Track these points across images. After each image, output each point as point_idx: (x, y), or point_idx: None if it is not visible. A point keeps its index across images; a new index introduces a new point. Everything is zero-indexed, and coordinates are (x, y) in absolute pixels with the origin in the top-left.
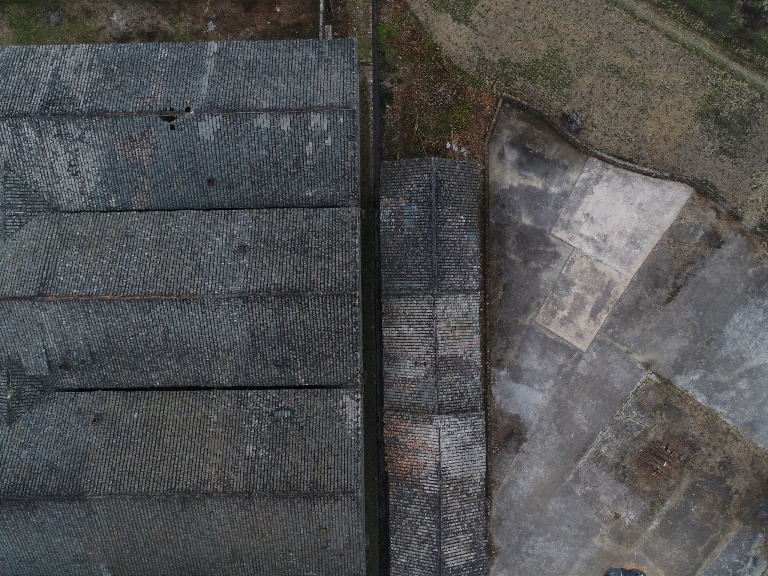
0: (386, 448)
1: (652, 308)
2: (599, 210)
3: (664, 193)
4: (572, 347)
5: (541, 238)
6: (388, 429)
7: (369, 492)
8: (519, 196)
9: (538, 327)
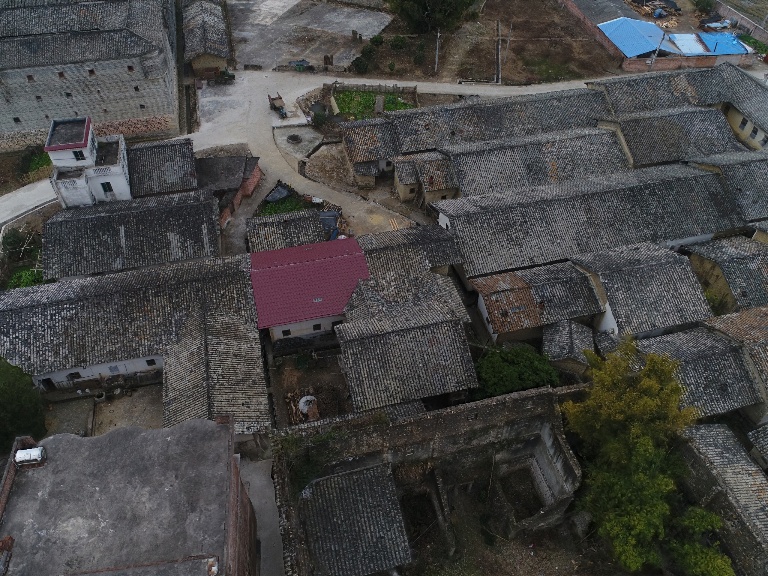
0: (183, 29)
1: (294, 16)
2: None
3: None
4: None
5: None
6: (184, 25)
7: (179, 56)
8: (238, 4)
9: None
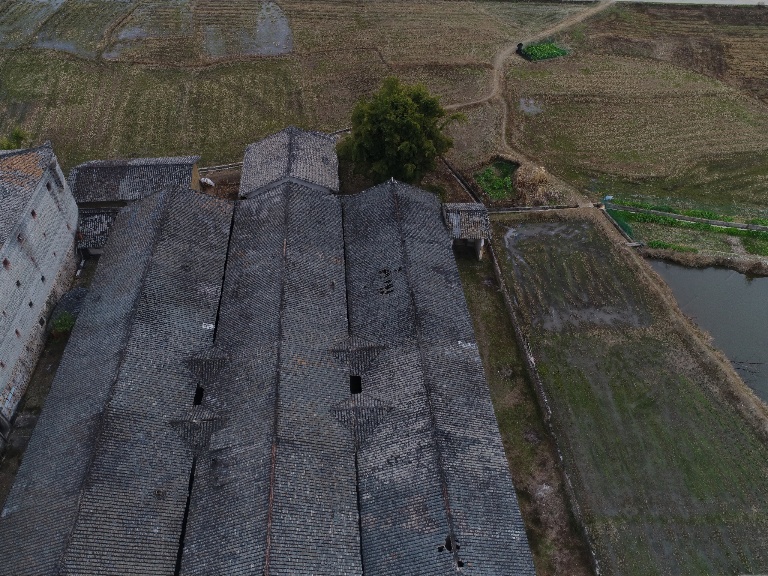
0: None
1: None
2: None
3: None
4: None
5: None
6: None
7: None
8: None
9: None
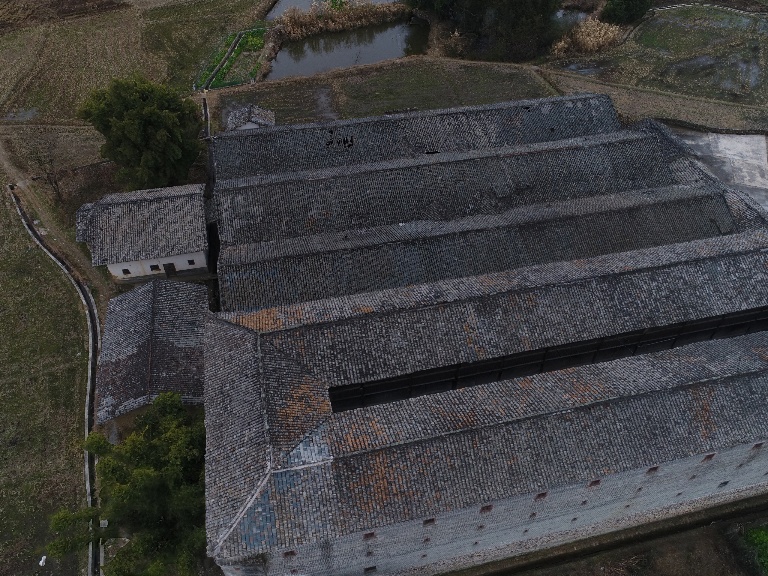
0: None
1: None
2: (729, 146)
3: (753, 138)
4: (764, 189)
5: (710, 157)
6: None
7: None
8: None
9: (740, 185)
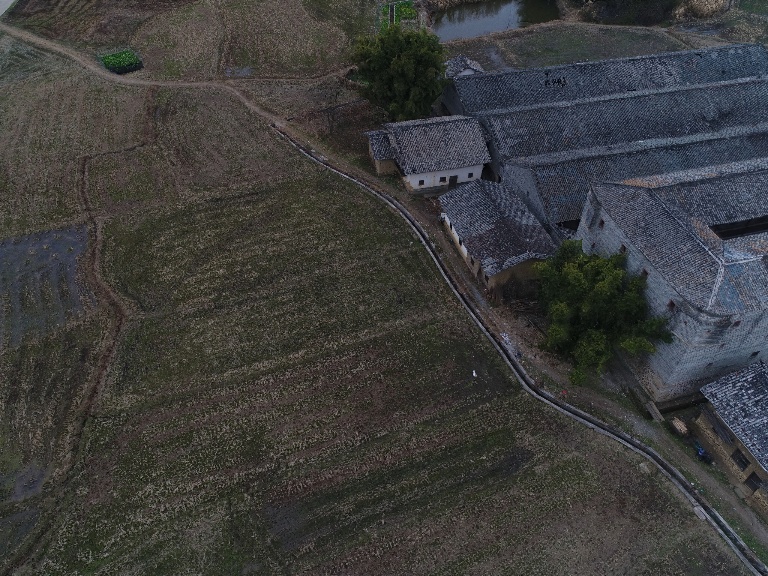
0: None
1: None
2: None
3: None
4: None
5: None
6: None
7: None
8: None
9: None
